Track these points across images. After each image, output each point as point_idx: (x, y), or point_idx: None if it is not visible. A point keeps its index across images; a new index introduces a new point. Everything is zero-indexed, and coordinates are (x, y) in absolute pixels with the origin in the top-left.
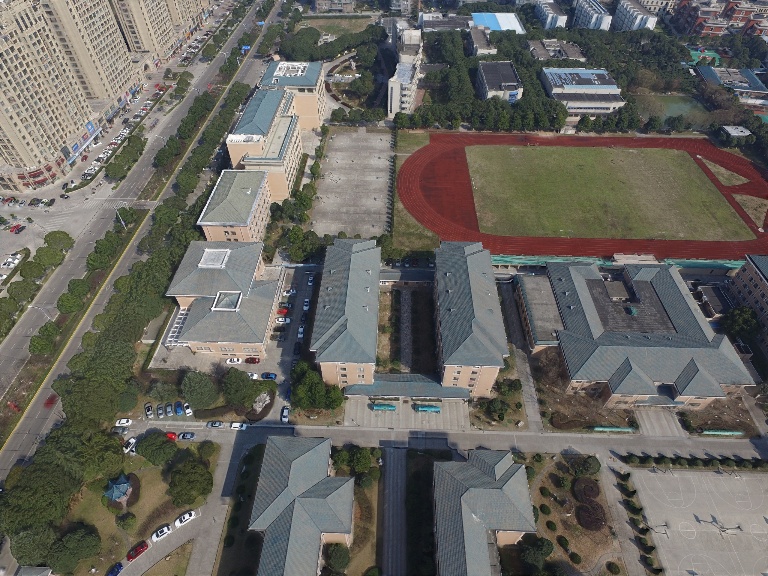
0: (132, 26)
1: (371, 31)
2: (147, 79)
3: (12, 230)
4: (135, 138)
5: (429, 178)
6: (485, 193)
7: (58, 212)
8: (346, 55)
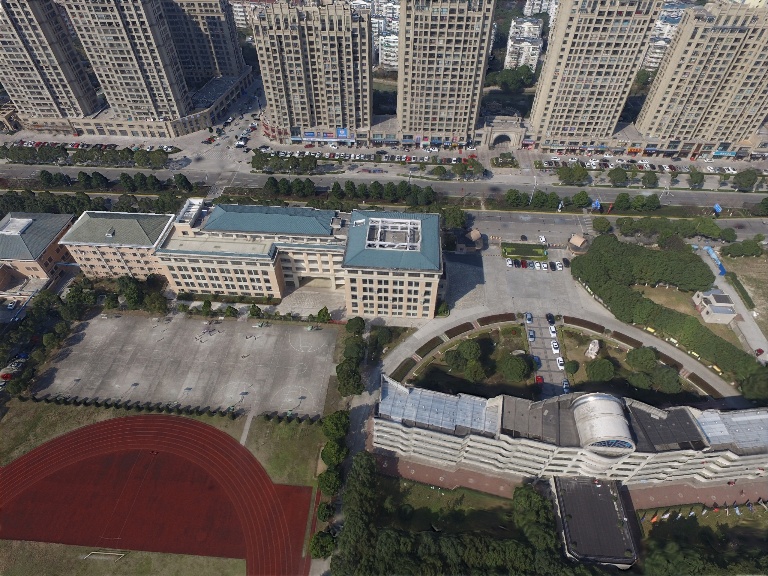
0: (537, 95)
1: (756, 371)
2: (488, 147)
3: (206, 139)
4: (307, 159)
5: (157, 468)
6: (65, 571)
7: (226, 153)
8: (665, 343)
